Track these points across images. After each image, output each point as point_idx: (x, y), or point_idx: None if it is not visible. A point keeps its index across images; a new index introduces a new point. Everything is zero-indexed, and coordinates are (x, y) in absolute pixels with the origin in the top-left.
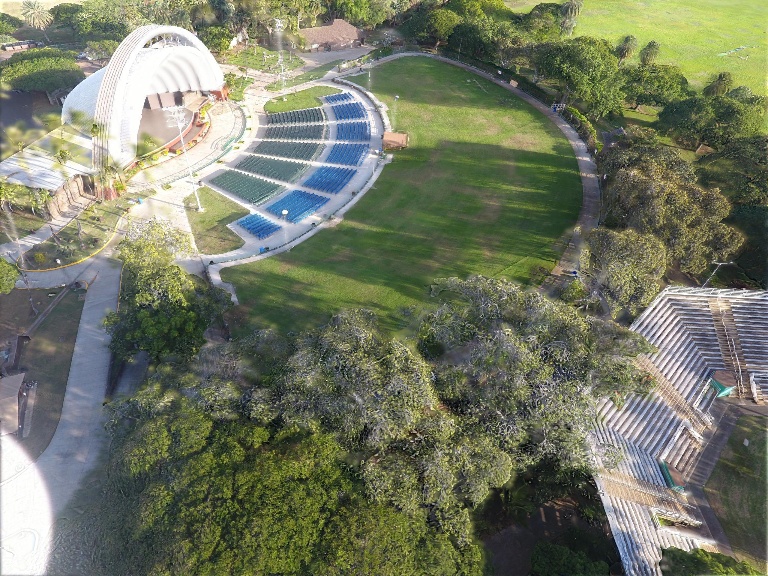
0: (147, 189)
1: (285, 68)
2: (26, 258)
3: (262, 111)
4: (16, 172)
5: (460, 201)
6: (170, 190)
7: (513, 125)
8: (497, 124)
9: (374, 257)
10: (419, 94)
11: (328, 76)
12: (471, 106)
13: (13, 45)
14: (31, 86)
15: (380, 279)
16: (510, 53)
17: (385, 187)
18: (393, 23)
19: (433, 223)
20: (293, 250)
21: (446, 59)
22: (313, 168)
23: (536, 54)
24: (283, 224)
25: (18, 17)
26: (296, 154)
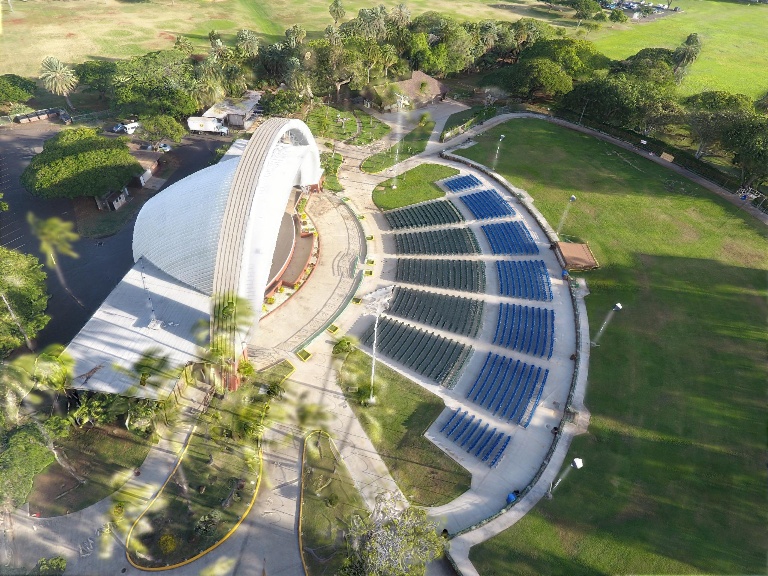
0: (277, 361)
1: (370, 137)
2: (153, 559)
3: (373, 206)
4: (98, 366)
5: (734, 370)
6: (310, 361)
7: (708, 223)
8: (687, 222)
9: (691, 506)
10: (559, 175)
11: (430, 148)
12: (635, 193)
13: (29, 116)
14: (77, 192)
15: (736, 565)
16: (662, 121)
17: (610, 343)
18: (467, 70)
19: (728, 420)
20: (556, 493)
21: (563, 122)
22: (488, 306)
23: (717, 129)
24: (507, 428)
25: (25, 73)
26: (456, 283)
